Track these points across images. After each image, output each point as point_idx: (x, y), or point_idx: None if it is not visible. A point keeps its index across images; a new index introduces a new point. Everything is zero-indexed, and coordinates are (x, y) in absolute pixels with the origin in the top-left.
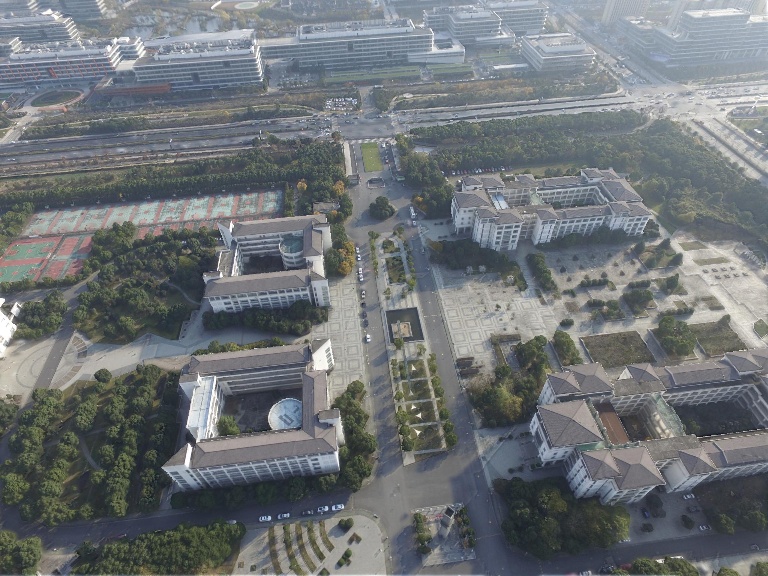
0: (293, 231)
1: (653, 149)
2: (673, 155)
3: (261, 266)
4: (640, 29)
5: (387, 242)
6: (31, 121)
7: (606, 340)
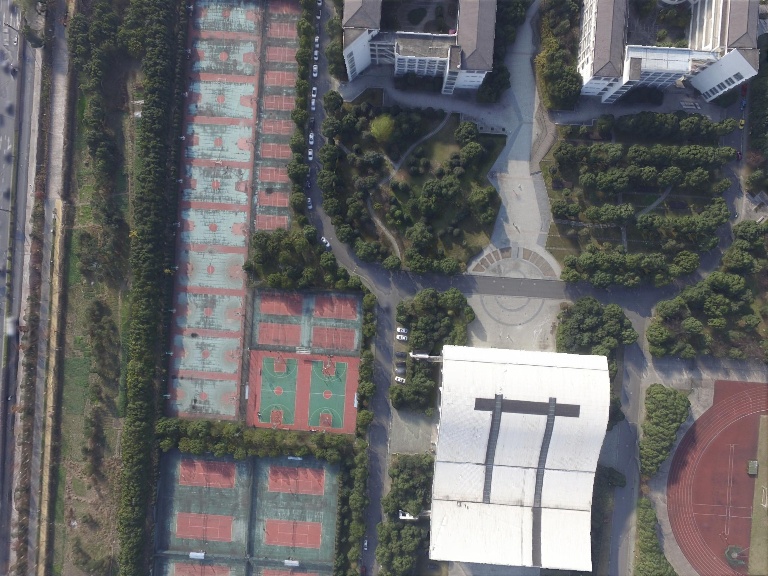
0: None
1: None
2: None
3: (394, 28)
4: None
5: None
6: None
7: None
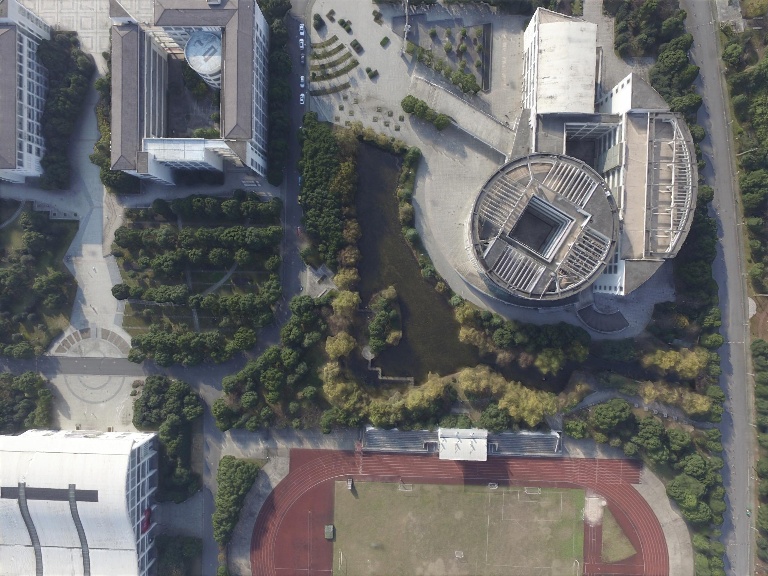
0: None
1: None
2: None
3: None
4: None
5: None
6: None
7: None
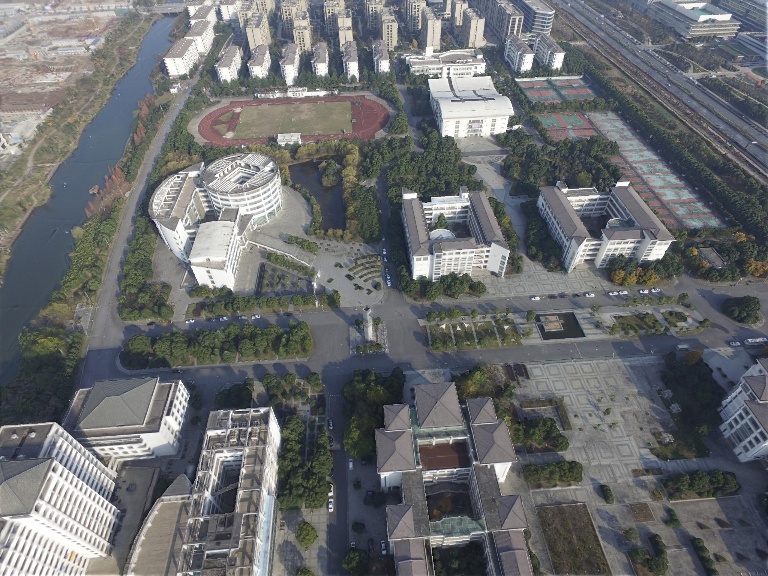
0: (636, 221)
1: None
2: None
3: (601, 225)
4: None
5: (682, 315)
6: (726, 75)
7: (588, 537)
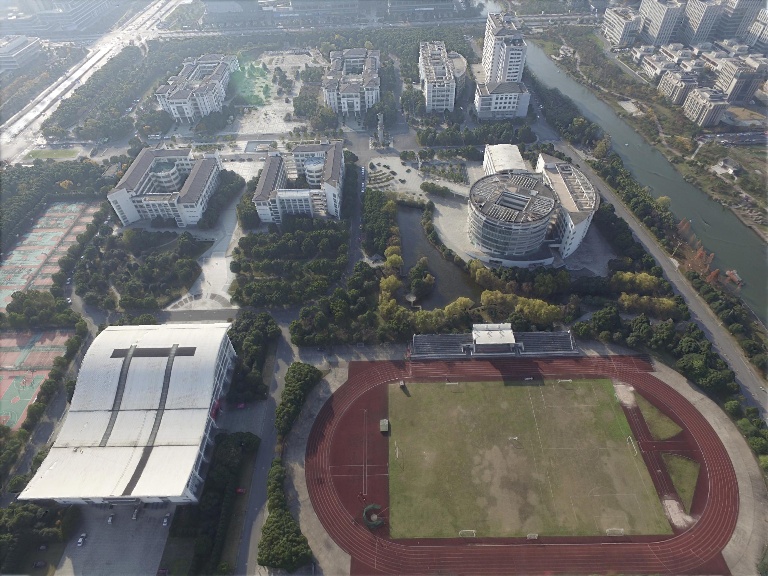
0: None
1: (175, 50)
2: (187, 46)
3: None
4: (26, 19)
5: None
6: None
7: (303, 93)
